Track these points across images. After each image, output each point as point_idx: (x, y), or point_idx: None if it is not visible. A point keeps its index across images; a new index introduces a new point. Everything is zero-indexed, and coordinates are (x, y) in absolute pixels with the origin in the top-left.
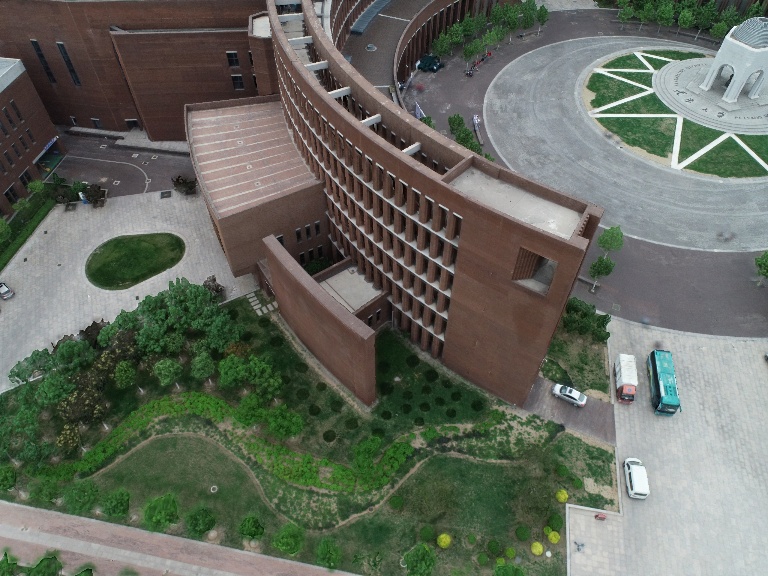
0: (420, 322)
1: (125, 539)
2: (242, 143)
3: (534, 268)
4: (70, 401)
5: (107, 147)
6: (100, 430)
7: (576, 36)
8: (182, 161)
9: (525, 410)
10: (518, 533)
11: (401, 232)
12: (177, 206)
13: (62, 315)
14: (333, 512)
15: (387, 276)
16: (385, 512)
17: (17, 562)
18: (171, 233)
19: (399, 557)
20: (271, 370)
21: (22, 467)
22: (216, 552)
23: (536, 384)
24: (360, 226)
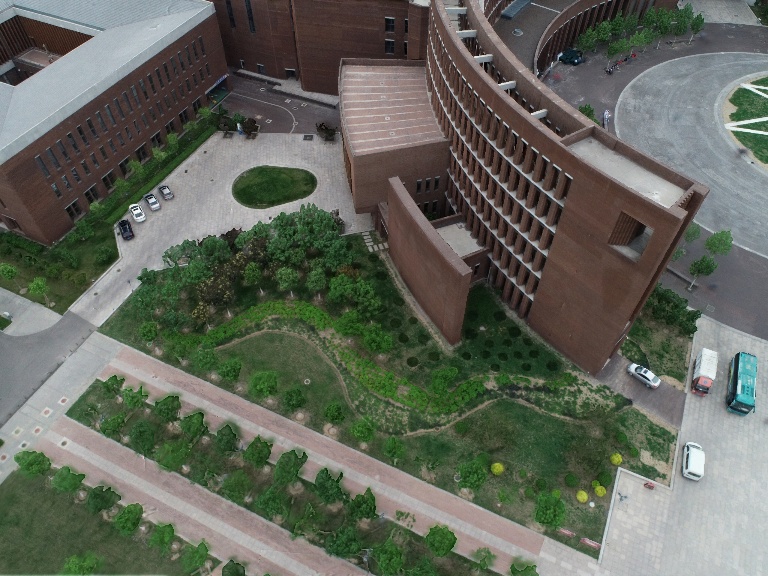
0: (514, 280)
1: (230, 403)
2: (385, 98)
3: (631, 236)
4: (207, 284)
5: (266, 90)
6: (224, 316)
7: (729, 50)
8: (327, 111)
9: (597, 380)
10: (567, 478)
11: (513, 190)
12: (316, 149)
13: (208, 220)
14: (404, 423)
15: (492, 232)
16: (449, 434)
17: (146, 400)
18: (307, 170)
19: (454, 473)
20: (374, 293)
21: (160, 330)
22: (300, 430)
23: (613, 360)
24: (476, 183)
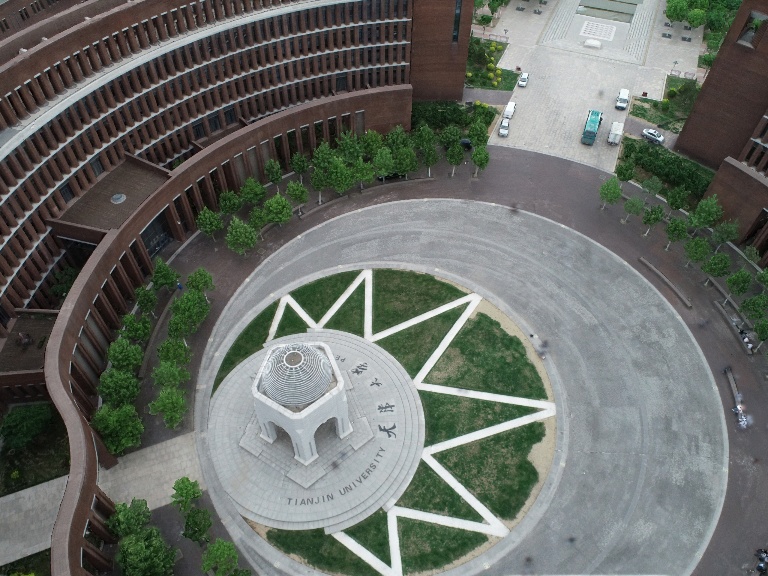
0: None
1: None
2: None
3: None
4: None
5: None
6: None
7: None
8: None
9: None
10: None
11: None
12: None
13: None
14: None
15: None
16: None
17: None
18: None
19: None
20: None
21: None
22: None
23: None
24: None
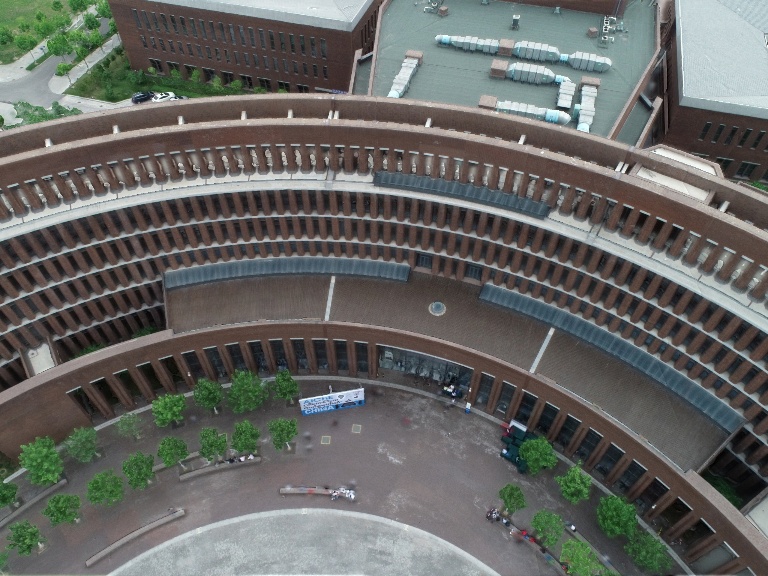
0: None
1: None
2: None
3: None
4: None
5: None
6: None
7: None
8: None
9: None
10: None
11: None
12: None
13: None
14: None
15: None
16: None
17: None
18: None
19: None
20: None
21: None
22: None
23: None
24: None
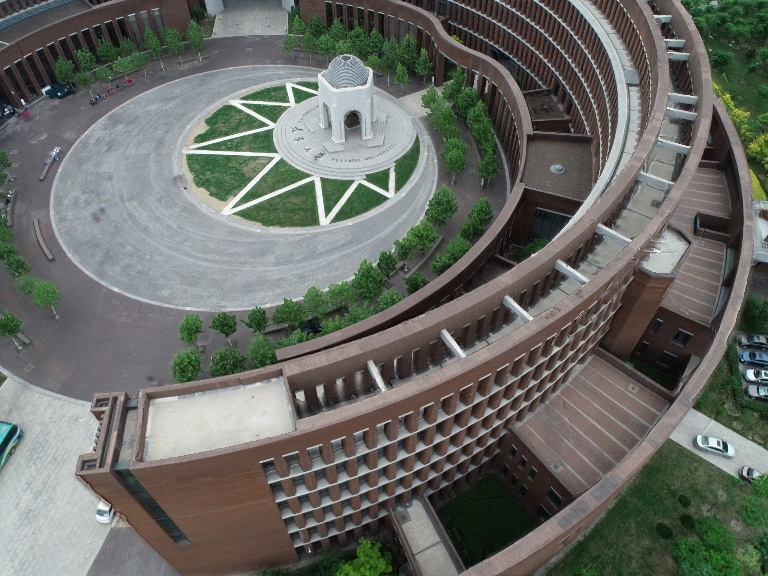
0: None
1: None
2: None
3: None
4: None
5: None
6: None
7: (240, 64)
8: None
9: None
10: None
11: None
12: None
13: None
14: None
15: None
16: None
17: None
18: None
19: None
20: None
21: None
22: None
23: None
24: None
